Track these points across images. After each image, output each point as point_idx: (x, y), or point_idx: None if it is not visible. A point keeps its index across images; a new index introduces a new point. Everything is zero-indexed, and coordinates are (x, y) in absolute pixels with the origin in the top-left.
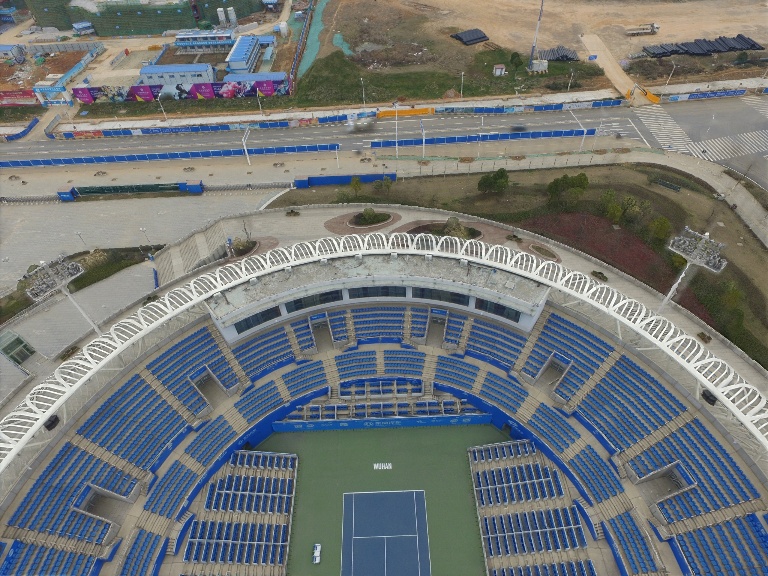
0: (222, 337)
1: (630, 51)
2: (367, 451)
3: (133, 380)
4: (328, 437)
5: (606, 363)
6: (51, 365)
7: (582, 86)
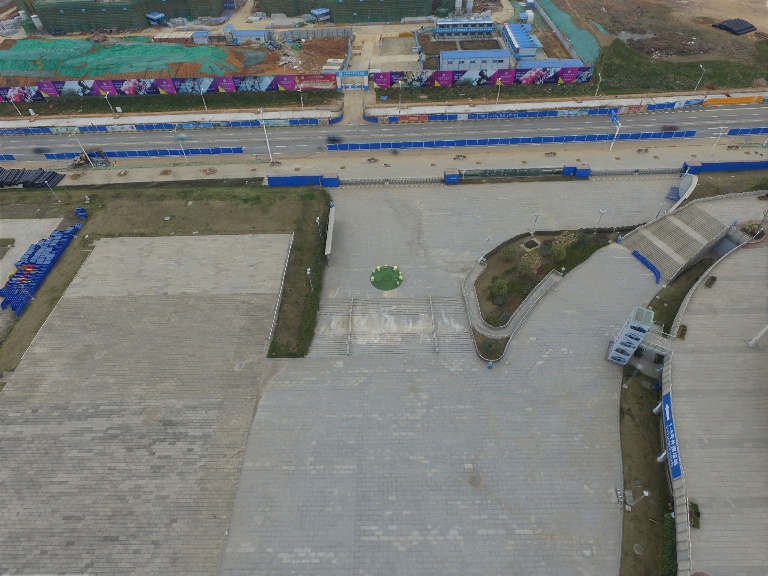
0: None
1: None
2: None
3: None
4: None
5: None
6: (673, 343)
7: None
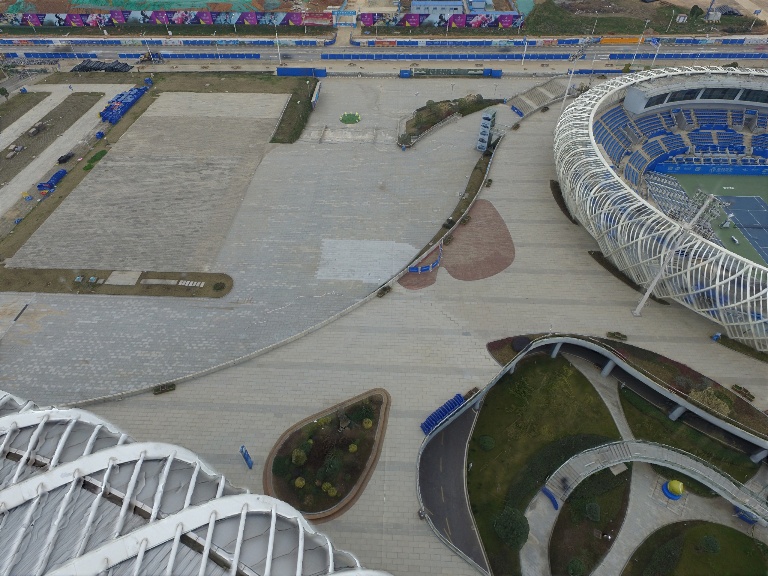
0: (628, 113)
1: None
2: (715, 182)
3: (597, 122)
4: (687, 177)
5: None
6: (509, 131)
7: (752, 31)
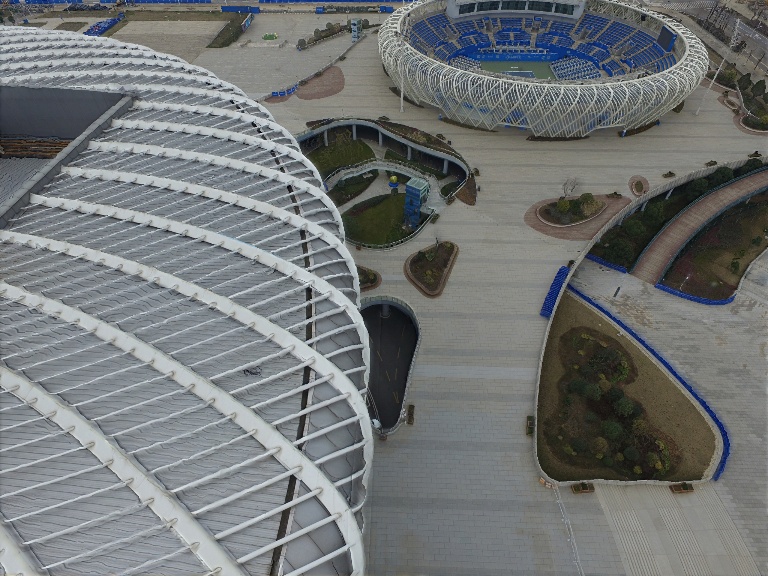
0: (450, 19)
1: None
2: (507, 65)
3: (422, 21)
4: (490, 62)
5: (607, 25)
6: (371, 34)
7: None
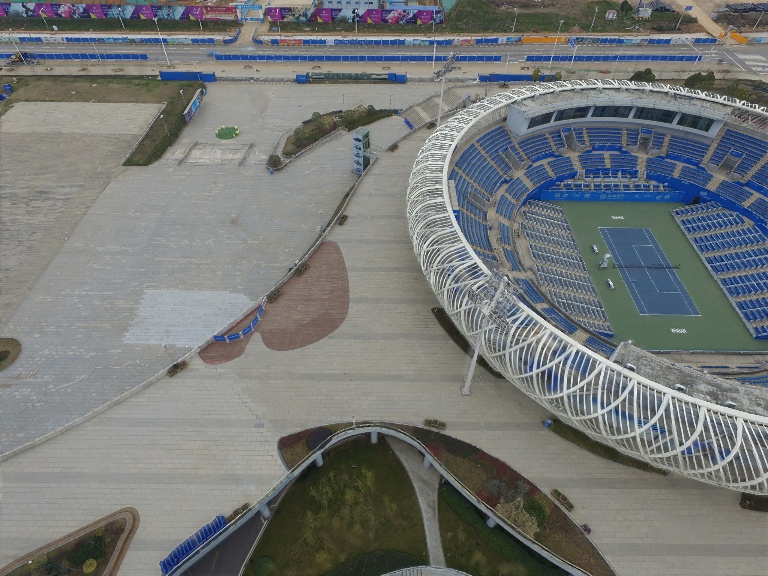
0: (511, 134)
1: (715, 7)
2: (604, 211)
3: (472, 146)
4: (575, 204)
5: None
6: (385, 153)
7: (681, 29)
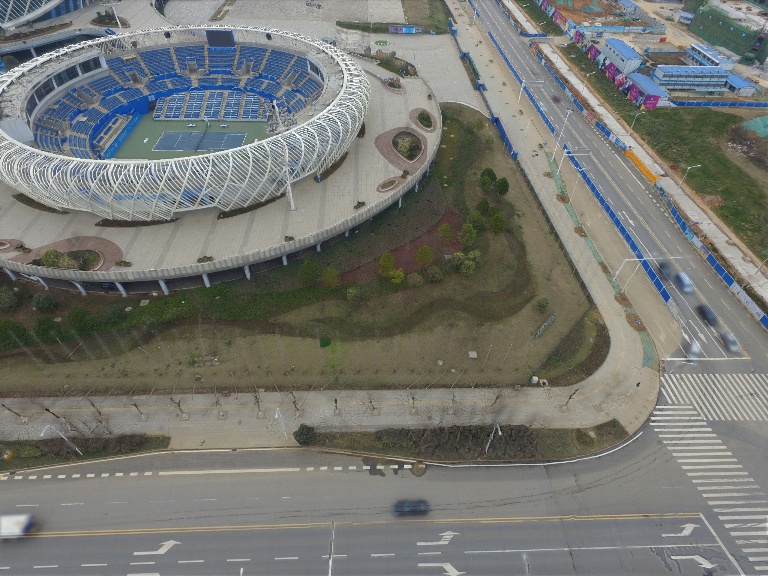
0: None
1: None
2: (265, 137)
3: (293, 55)
4: None
5: None
6: None
7: None
